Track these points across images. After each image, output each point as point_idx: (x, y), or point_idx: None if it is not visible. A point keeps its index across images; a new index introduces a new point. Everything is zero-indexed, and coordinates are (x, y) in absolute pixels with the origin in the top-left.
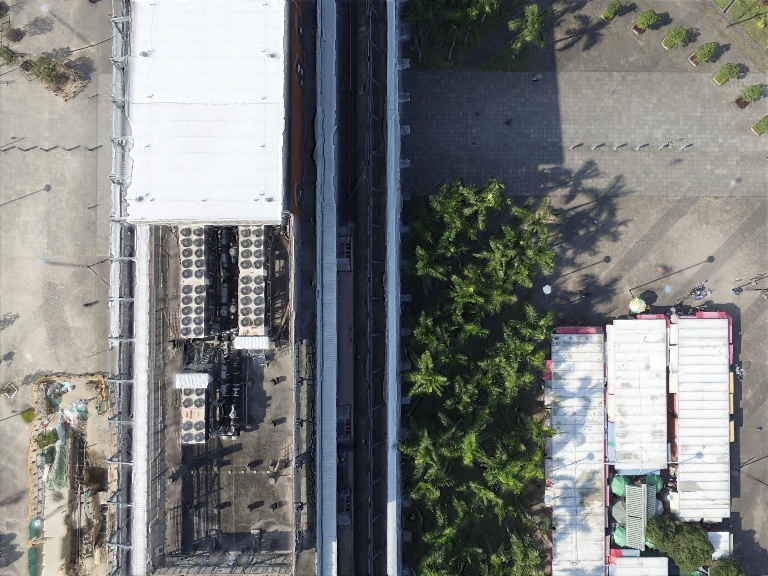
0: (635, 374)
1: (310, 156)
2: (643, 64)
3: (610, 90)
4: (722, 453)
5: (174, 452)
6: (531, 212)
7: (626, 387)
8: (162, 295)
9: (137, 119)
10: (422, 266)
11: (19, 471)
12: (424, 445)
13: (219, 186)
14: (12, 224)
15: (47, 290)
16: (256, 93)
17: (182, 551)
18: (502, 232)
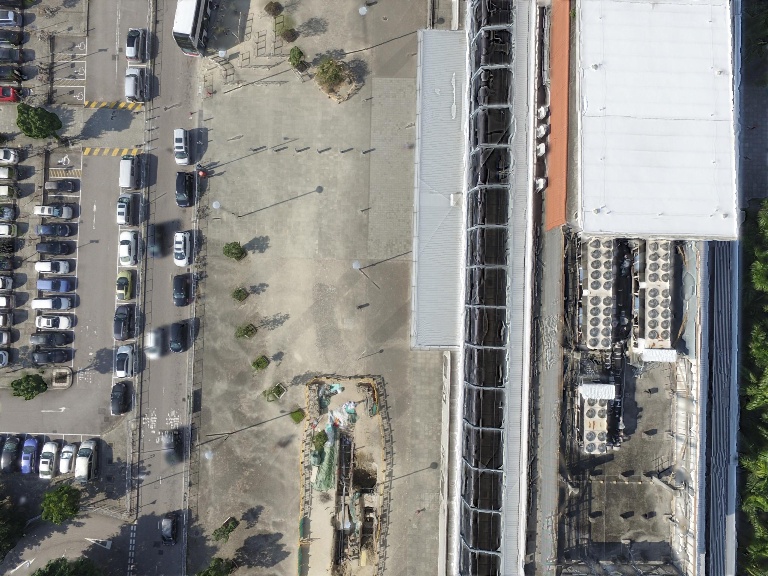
0: None
1: None
2: None
3: None
4: None
5: (549, 461)
6: None
7: None
8: (537, 304)
9: (590, 132)
10: (759, 281)
11: (286, 471)
12: (764, 459)
13: (675, 201)
14: (283, 225)
15: (317, 291)
16: (706, 109)
17: (557, 559)
18: None
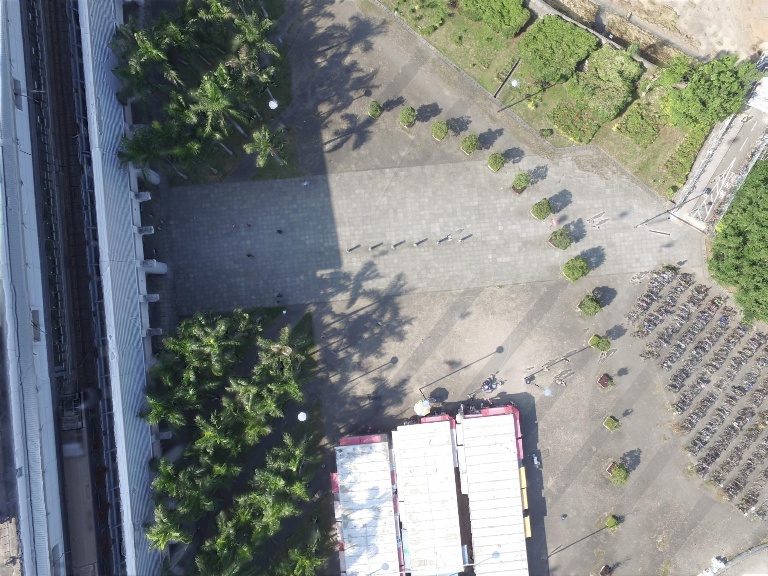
0: (423, 479)
1: (4, 329)
2: (415, 158)
3: (384, 188)
4: (519, 550)
5: None
6: (313, 319)
7: (415, 493)
8: None
9: None
10: (154, 415)
11: None
12: None
13: None
14: None
15: None
16: None
17: None
18: (258, 358)
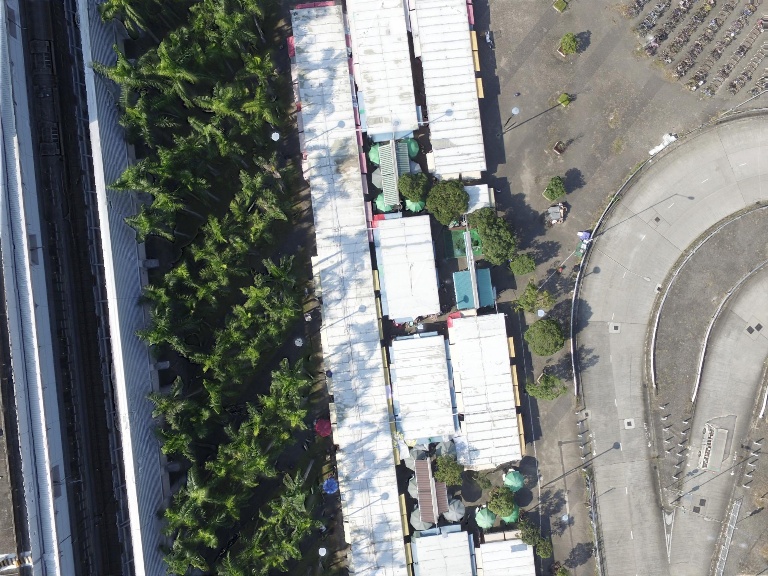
0: (376, 40)
1: None
2: None
3: None
4: (471, 108)
5: None
6: None
7: (369, 53)
8: None
9: None
10: None
11: None
12: (120, 64)
13: None
14: None
15: None
16: None
17: None
18: None
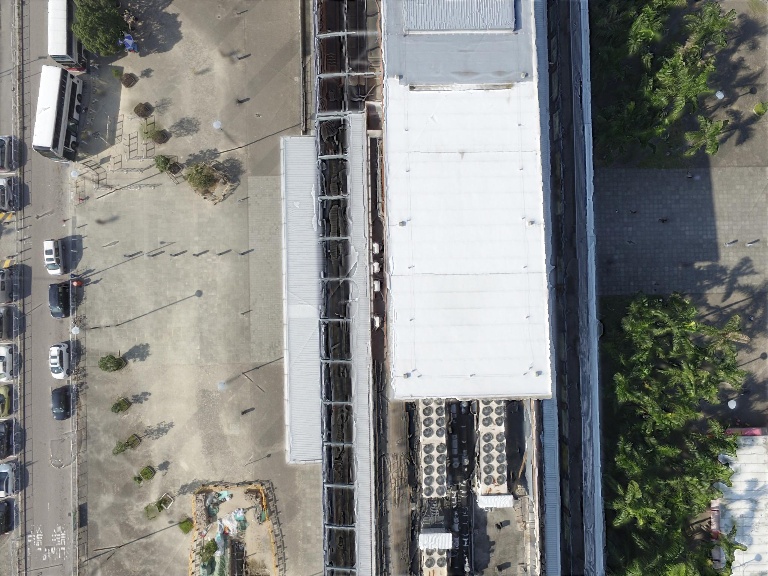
0: None
1: None
2: None
3: (763, 185)
4: None
5: None
6: None
7: None
8: (382, 441)
9: (399, 292)
10: (622, 392)
11: None
12: (631, 575)
13: (487, 360)
14: (163, 331)
15: (201, 398)
16: (518, 262)
17: None
18: (681, 344)
